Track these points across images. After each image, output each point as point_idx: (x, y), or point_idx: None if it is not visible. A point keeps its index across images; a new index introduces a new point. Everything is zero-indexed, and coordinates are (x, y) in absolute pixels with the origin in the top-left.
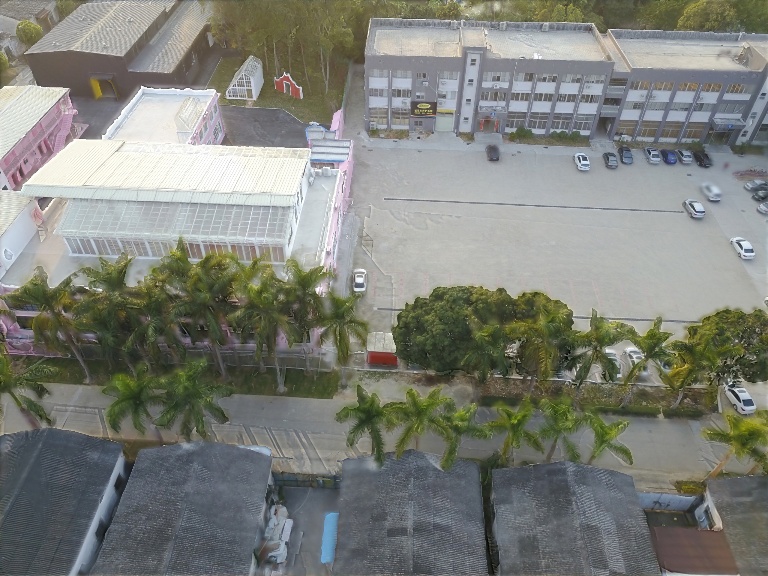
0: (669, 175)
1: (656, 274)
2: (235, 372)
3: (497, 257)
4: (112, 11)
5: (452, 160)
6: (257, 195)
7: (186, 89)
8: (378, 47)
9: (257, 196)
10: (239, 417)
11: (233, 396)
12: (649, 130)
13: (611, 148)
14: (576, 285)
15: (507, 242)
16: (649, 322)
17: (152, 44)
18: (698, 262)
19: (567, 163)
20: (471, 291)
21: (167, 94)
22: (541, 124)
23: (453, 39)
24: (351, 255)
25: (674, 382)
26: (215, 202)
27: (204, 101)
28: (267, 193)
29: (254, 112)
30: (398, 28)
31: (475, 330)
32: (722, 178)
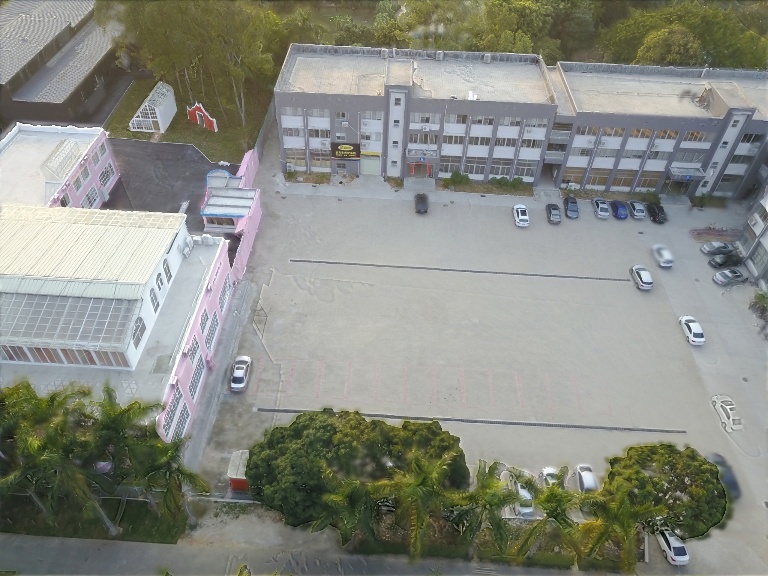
0: (618, 233)
1: (590, 364)
2: (62, 505)
3: (408, 340)
4: (6, 27)
5: (375, 211)
6: (99, 284)
7: (69, 126)
8: (294, 80)
9: (99, 285)
10: (54, 572)
11: (53, 540)
12: (599, 178)
13: (556, 198)
14: (496, 378)
15: (423, 319)
16: (576, 429)
17: (49, 66)
18: (640, 348)
19: (505, 216)
20: (335, 428)
21: (47, 132)
22: (479, 169)
23: (381, 71)
24: (238, 336)
25: (581, 548)
26: (46, 293)
27: (88, 142)
28: (112, 281)
29: (158, 148)
30: (322, 56)
31: (330, 488)
32: (677, 237)
